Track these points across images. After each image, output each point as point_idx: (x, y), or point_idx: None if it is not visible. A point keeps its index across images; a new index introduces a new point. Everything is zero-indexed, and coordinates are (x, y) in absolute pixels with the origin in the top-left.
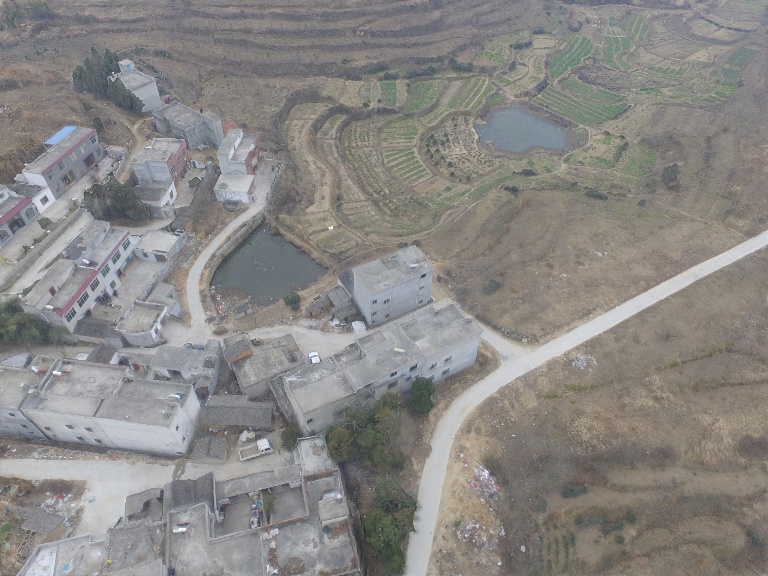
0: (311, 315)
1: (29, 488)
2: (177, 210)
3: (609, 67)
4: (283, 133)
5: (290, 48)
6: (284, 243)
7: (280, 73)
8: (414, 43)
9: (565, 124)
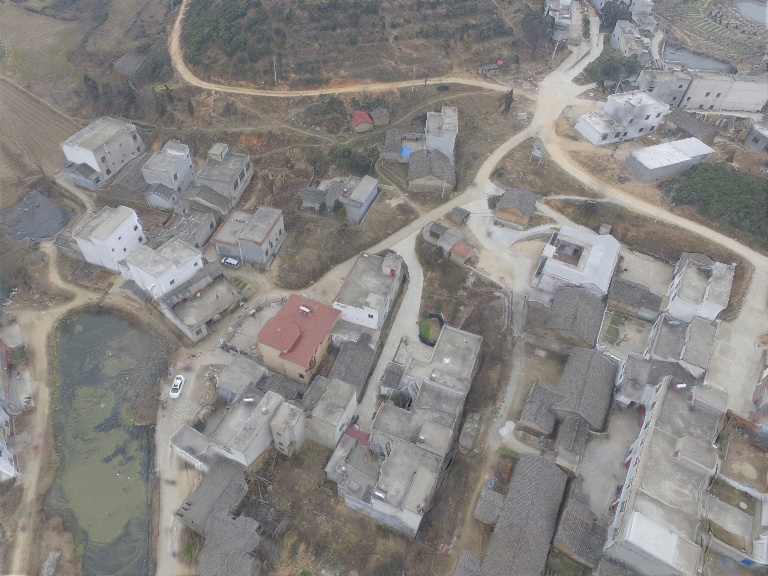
0: None
1: (704, 117)
2: None
3: None
4: None
5: None
6: (689, 53)
7: None
8: None
9: None
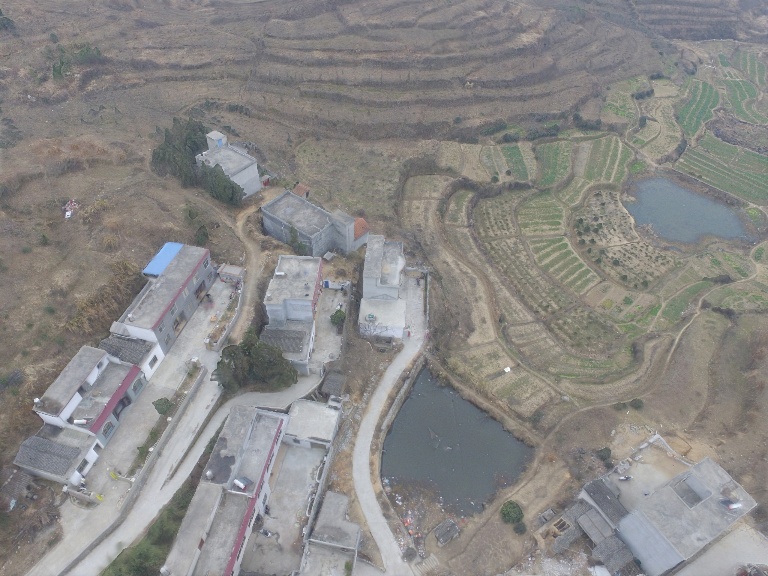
0: (556, 553)
1: None
2: (327, 366)
3: (742, 120)
4: (405, 220)
5: (392, 104)
6: (461, 401)
7: (383, 135)
8: (530, 95)
9: (731, 202)
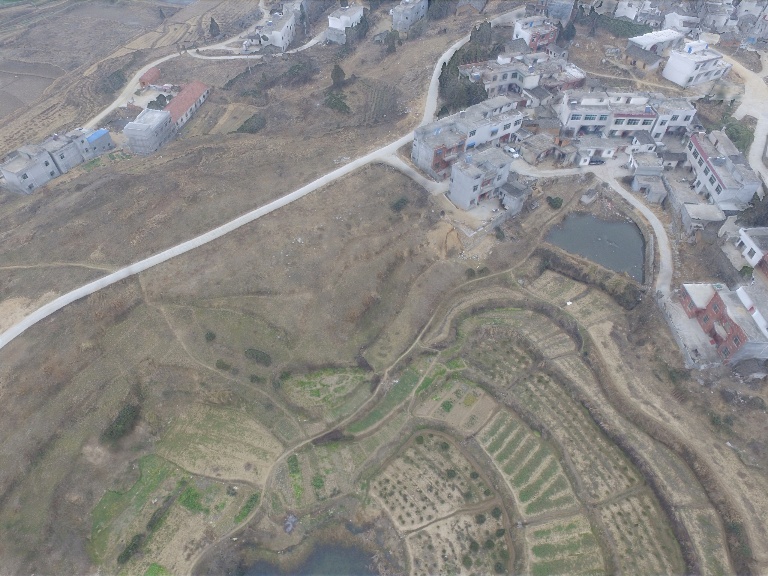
0: None
1: None
2: None
3: None
4: None
5: None
6: None
7: None
8: None
9: None
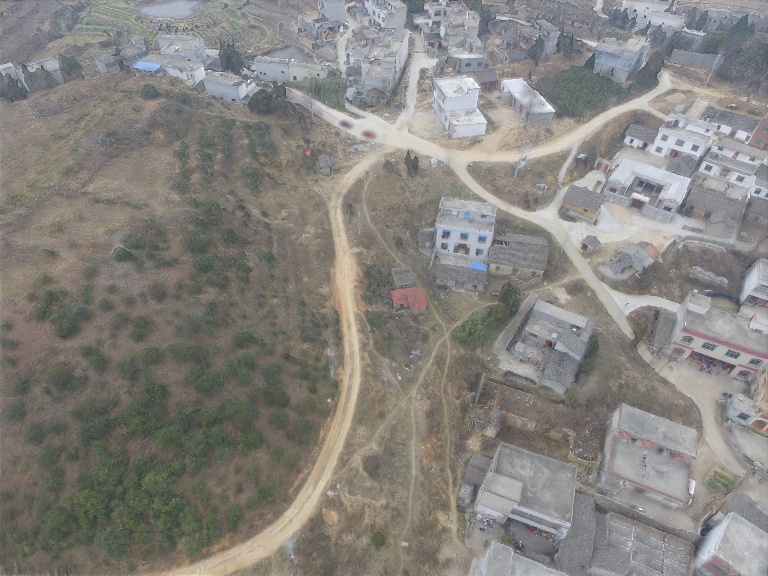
0: None
1: None
2: None
3: None
4: None
5: None
6: None
7: (26, 55)
8: (34, 8)
9: None
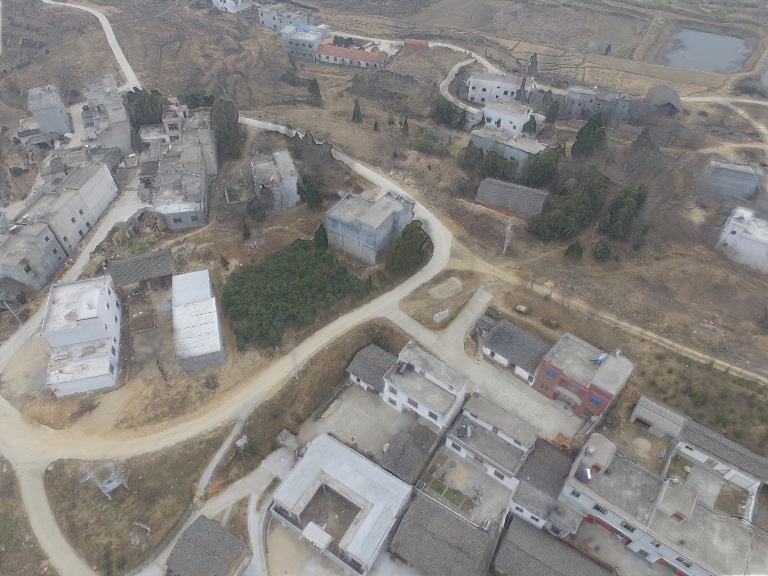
0: (42, 157)
1: None
2: None
3: None
4: None
5: None
6: None
7: None
8: None
9: None
